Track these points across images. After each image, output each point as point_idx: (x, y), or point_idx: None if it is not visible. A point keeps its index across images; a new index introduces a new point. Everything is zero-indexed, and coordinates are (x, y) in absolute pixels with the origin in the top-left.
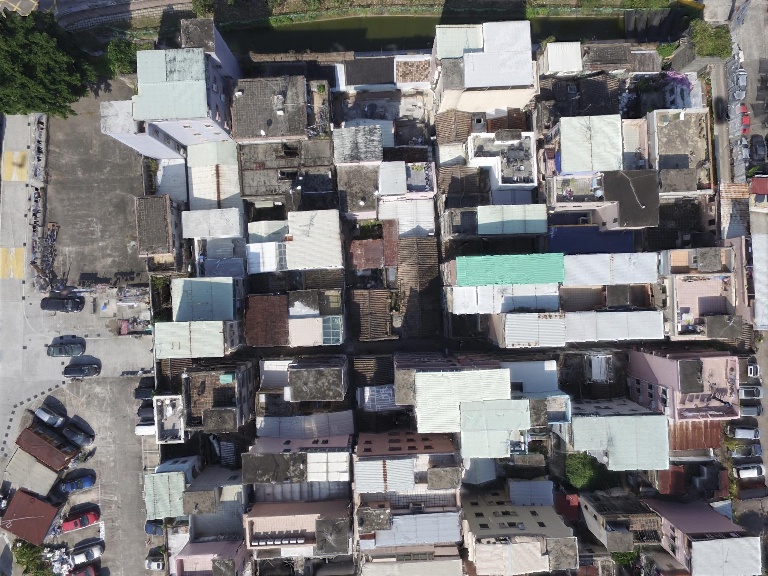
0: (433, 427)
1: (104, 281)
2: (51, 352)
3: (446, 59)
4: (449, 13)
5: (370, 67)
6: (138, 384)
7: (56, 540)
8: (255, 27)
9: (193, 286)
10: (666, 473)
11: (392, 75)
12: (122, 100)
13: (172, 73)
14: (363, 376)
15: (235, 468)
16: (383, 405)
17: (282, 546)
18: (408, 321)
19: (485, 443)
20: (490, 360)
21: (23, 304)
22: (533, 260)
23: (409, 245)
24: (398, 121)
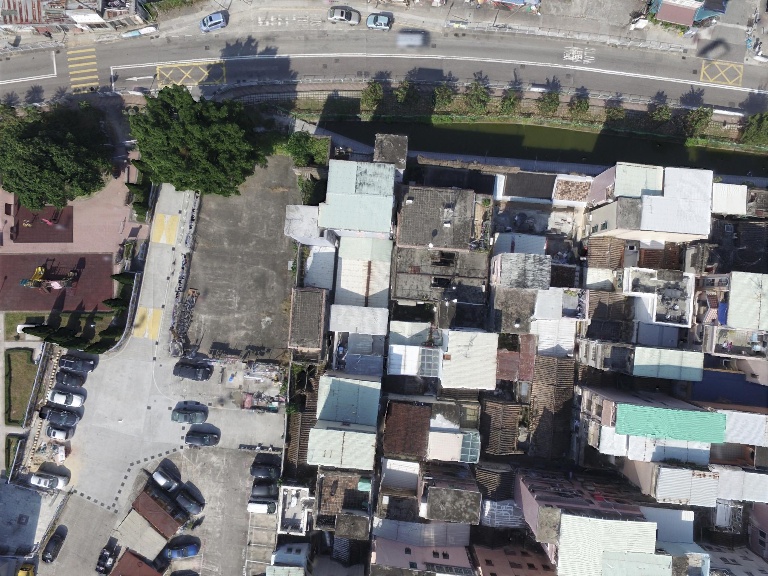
0: (573, 572)
1: (235, 352)
2: (176, 417)
3: (624, 198)
4: (608, 132)
5: (530, 181)
6: (254, 459)
7: None
8: (415, 122)
9: (341, 386)
10: None
11: (550, 192)
12: (309, 205)
13: (361, 185)
14: (484, 488)
15: (348, 565)
16: (502, 521)
17: None
18: (537, 440)
19: None
20: (630, 504)
21: (153, 365)
22: (696, 418)
23: (548, 365)
24: (546, 234)
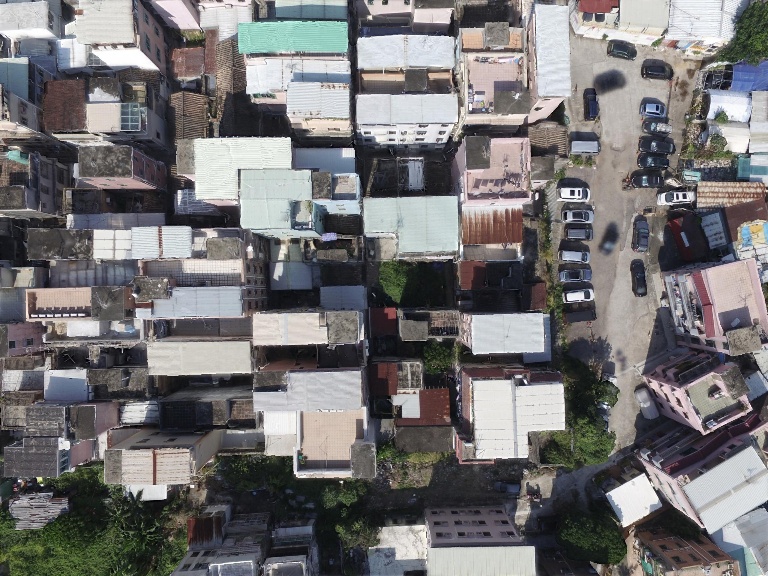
0: (211, 193)
1: None
2: None
3: None
4: None
5: None
6: None
7: None
8: None
9: None
10: (468, 268)
11: None
12: None
13: None
14: (178, 181)
15: (42, 266)
16: (196, 209)
17: (62, 318)
18: (224, 126)
19: (265, 213)
20: None
21: None
22: (315, 27)
23: (226, 49)
24: None
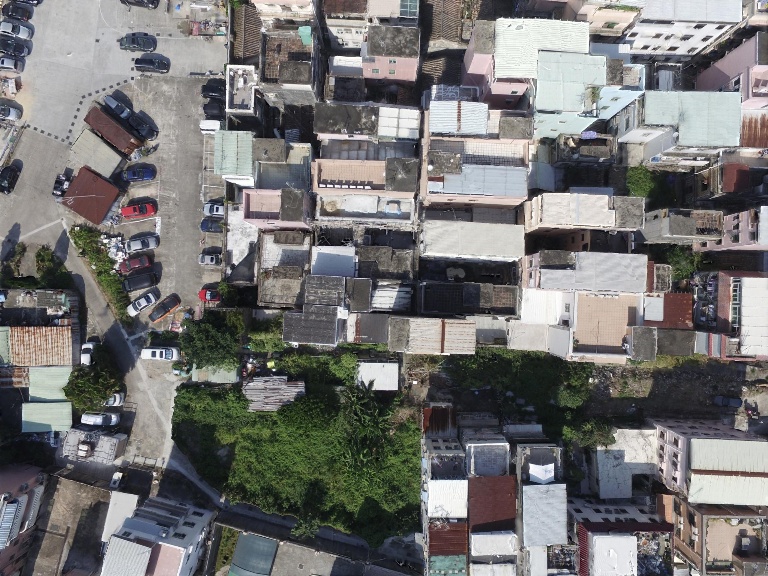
0: (510, 72)
1: None
2: (124, 42)
3: None
4: None
5: None
6: None
7: (113, 230)
8: None
9: None
10: (731, 171)
11: None
12: None
13: None
14: (431, 78)
15: None
16: None
17: (349, 189)
18: None
19: (560, 95)
20: None
21: None
22: None
23: None
24: None
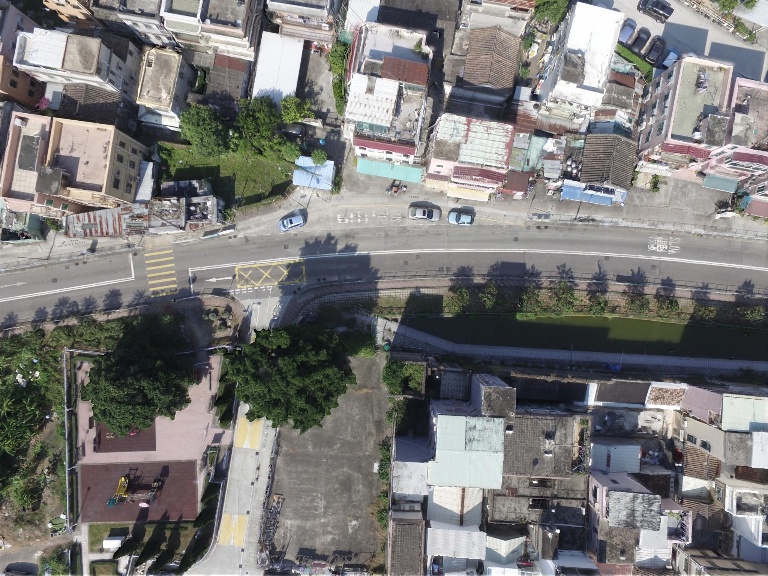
0: None
1: (322, 558)
2: None
3: (733, 433)
4: (696, 324)
5: (623, 389)
6: None
7: None
8: (500, 319)
9: None
10: None
11: (644, 398)
12: (417, 462)
13: (471, 442)
14: None
15: None
16: None
17: None
18: None
19: None
20: None
21: (239, 572)
22: None
23: None
24: (637, 434)
